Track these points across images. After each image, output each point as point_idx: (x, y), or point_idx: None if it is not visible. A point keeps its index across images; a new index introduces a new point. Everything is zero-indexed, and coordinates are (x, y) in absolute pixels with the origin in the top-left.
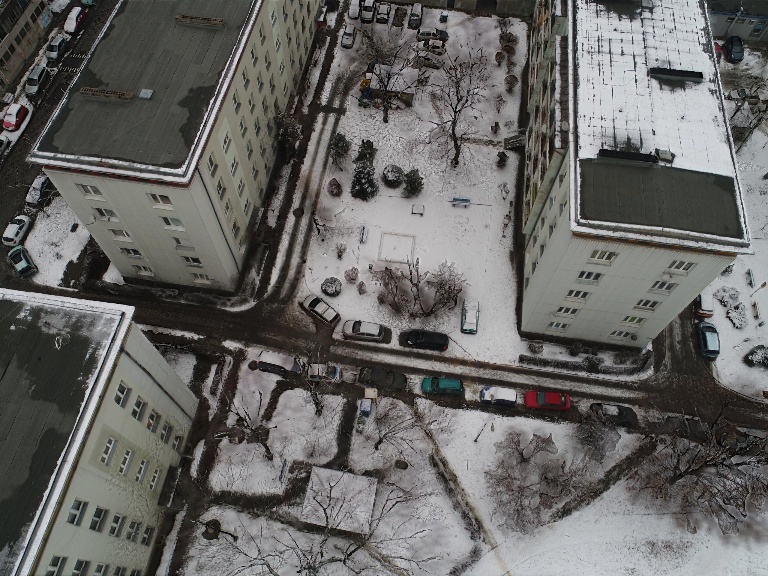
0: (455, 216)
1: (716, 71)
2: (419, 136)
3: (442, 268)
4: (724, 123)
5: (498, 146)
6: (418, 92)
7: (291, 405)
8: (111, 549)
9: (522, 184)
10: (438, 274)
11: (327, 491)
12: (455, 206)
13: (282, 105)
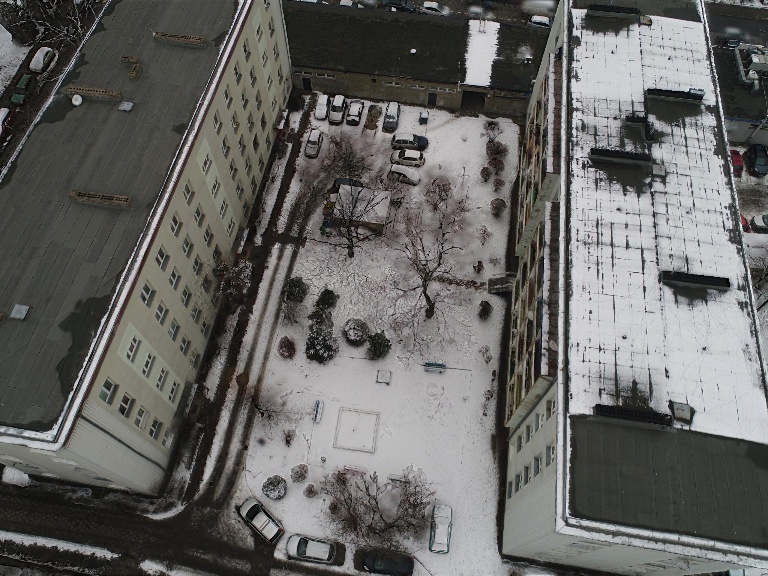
0: (428, 385)
1: (746, 272)
2: (389, 275)
3: (407, 474)
4: (758, 356)
5: (481, 289)
6: (390, 216)
7: None
8: None
9: (508, 341)
10: (402, 481)
11: None
12: (428, 371)
13: (226, 247)
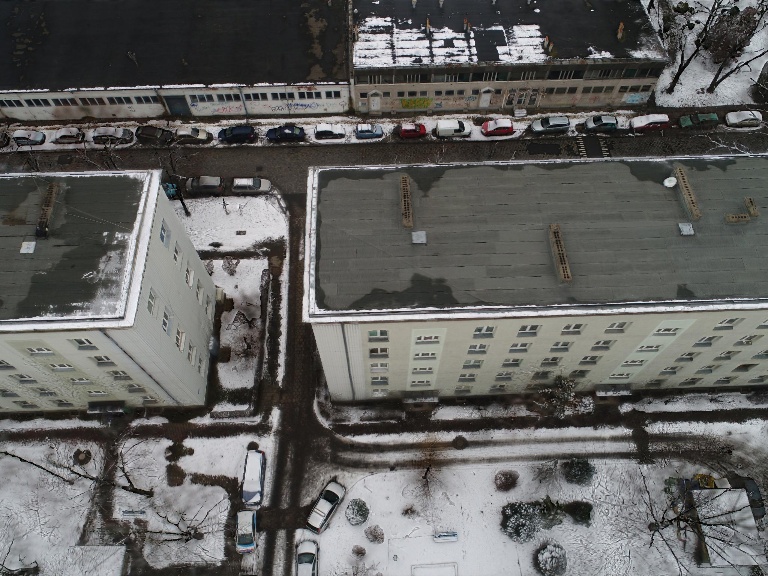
0: None
1: None
2: None
3: None
4: None
5: None
6: (733, 569)
7: (209, 501)
8: (6, 381)
9: None
10: None
11: (93, 570)
12: None
13: (596, 379)
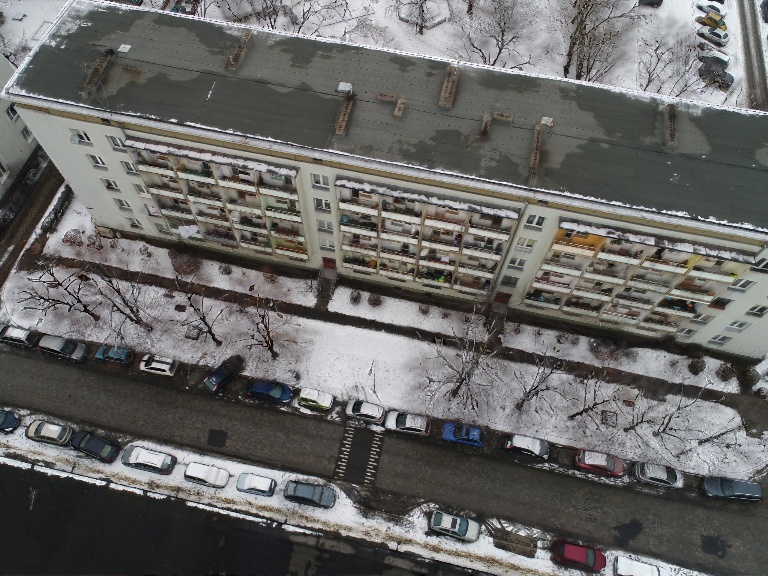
0: None
1: None
2: None
3: None
4: None
5: None
6: None
7: None
8: None
9: None
10: None
11: None
12: None
13: None
